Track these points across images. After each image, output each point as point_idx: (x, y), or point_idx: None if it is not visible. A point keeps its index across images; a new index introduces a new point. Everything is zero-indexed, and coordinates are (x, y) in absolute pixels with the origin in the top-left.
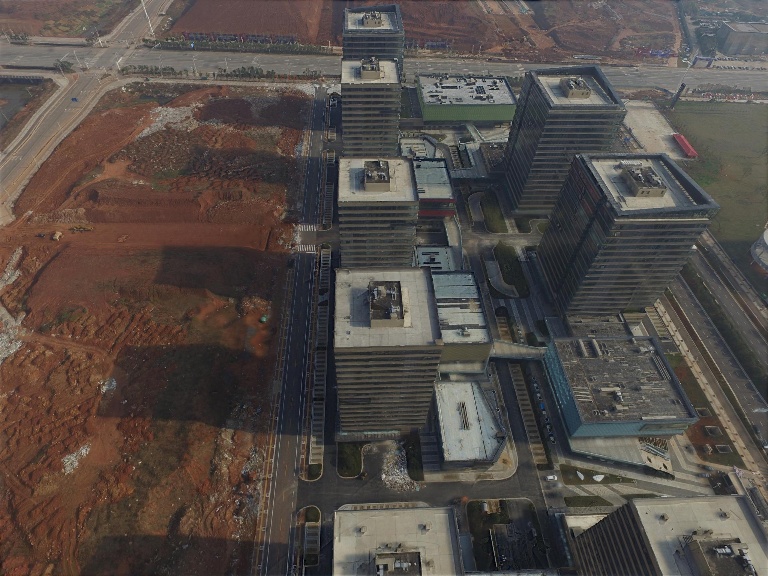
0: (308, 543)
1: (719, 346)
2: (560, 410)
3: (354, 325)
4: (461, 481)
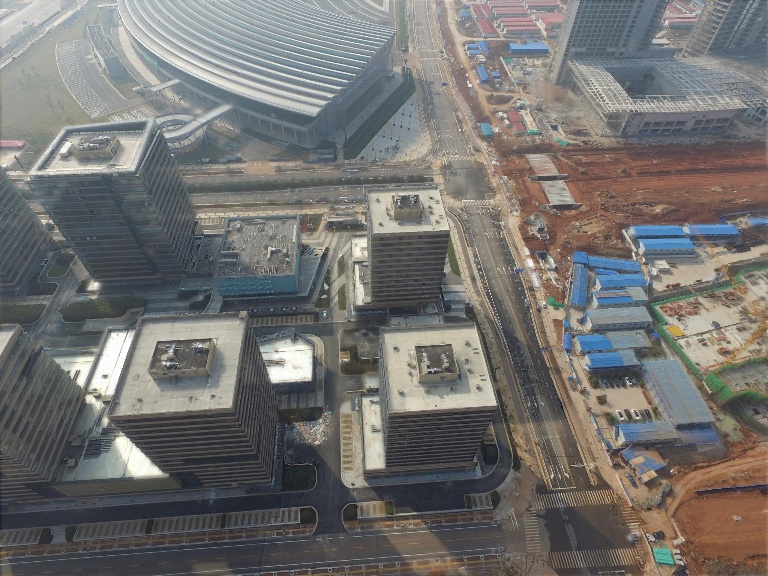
0: (376, 513)
1: (235, 197)
2: (274, 295)
3: (203, 392)
4: (324, 377)
